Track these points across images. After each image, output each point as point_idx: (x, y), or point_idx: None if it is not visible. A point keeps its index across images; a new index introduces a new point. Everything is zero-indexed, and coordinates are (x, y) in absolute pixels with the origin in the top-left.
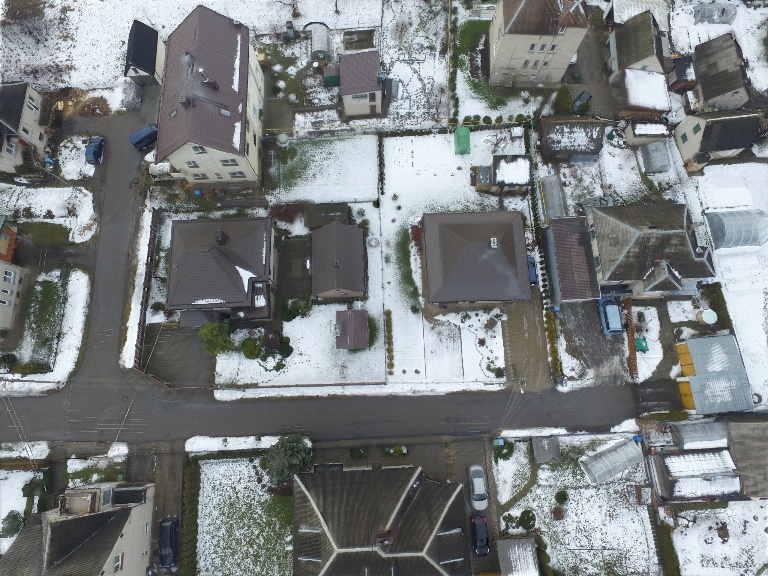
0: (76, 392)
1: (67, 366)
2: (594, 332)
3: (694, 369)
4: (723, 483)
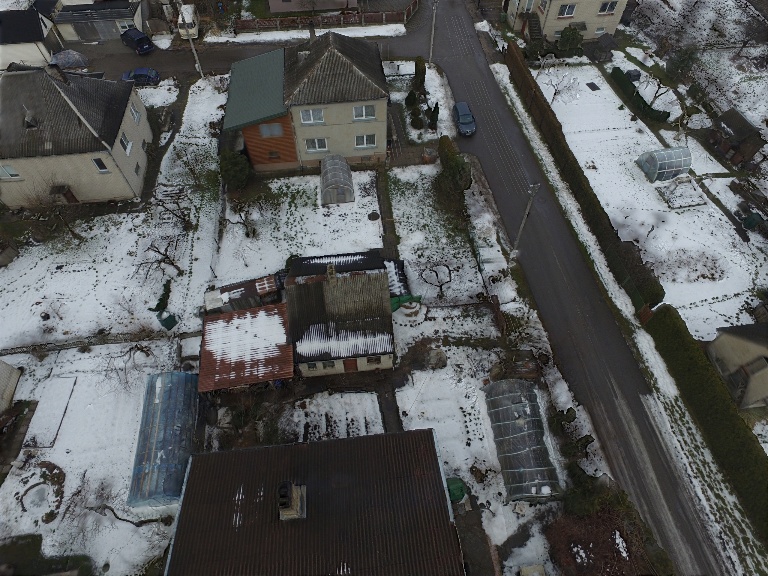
0: (436, 55)
1: (411, 65)
2: None
3: None
4: None
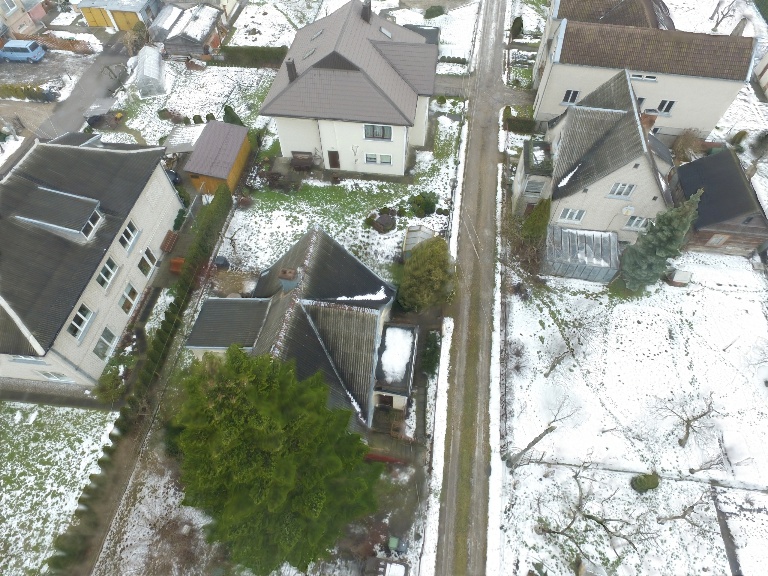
0: None
1: None
2: (32, 68)
3: (103, 7)
4: (205, 14)
